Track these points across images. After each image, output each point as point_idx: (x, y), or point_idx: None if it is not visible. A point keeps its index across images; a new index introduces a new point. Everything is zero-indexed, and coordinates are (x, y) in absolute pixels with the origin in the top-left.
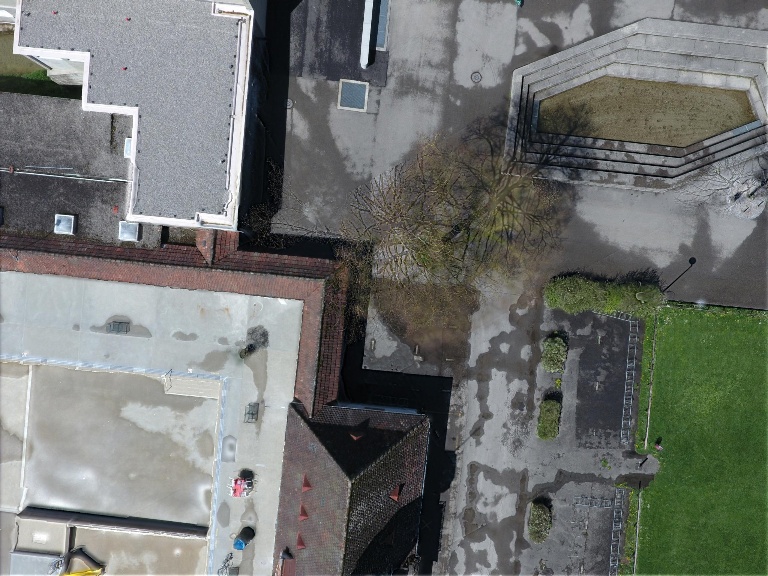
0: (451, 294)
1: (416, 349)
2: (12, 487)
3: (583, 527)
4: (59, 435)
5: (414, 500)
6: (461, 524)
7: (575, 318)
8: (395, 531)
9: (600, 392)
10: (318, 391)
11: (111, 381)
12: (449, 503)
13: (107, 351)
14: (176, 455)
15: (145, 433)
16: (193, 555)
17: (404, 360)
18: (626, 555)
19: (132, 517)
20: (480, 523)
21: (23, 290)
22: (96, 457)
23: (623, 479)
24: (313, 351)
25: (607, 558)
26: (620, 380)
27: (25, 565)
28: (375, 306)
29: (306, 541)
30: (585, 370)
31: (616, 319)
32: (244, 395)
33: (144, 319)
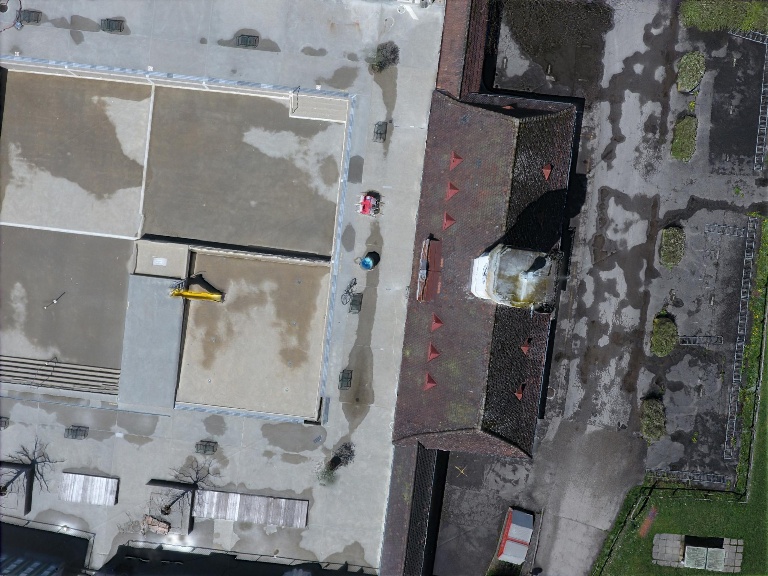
0: (585, 12)
1: (548, 69)
2: (130, 213)
3: (714, 257)
4: (180, 160)
5: (560, 189)
6: (590, 251)
7: (710, 39)
8: (544, 213)
9: (734, 116)
10: (465, 74)
11: (235, 104)
12: (579, 229)
13: (235, 66)
14: (299, 181)
15: (268, 158)
16: (315, 283)
17: (536, 80)
18: (757, 287)
19: (252, 246)
20: (610, 250)
21: (151, 2)
22: (217, 183)
23: (756, 208)
24: (461, 33)
25: (738, 290)
26: (755, 104)
27: (145, 288)
28: (508, 24)
29: (457, 214)
30: (719, 93)
31: (752, 41)
32: (373, 113)
33: (273, 33)
